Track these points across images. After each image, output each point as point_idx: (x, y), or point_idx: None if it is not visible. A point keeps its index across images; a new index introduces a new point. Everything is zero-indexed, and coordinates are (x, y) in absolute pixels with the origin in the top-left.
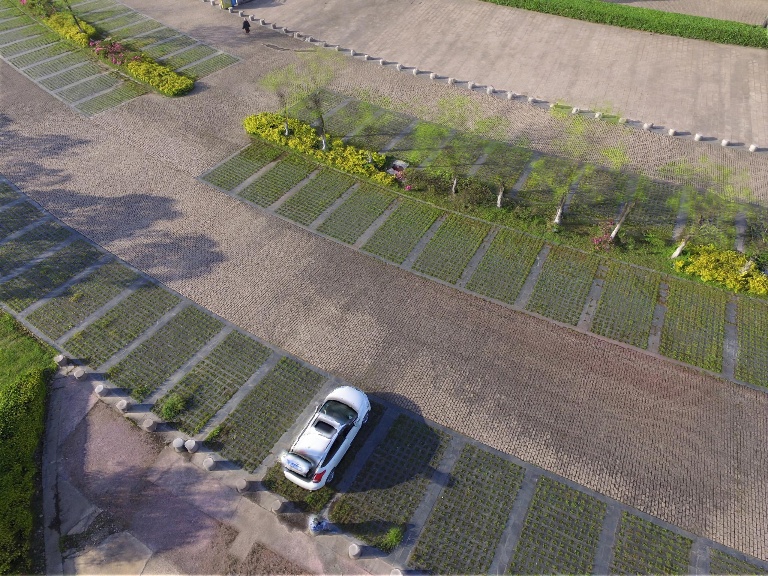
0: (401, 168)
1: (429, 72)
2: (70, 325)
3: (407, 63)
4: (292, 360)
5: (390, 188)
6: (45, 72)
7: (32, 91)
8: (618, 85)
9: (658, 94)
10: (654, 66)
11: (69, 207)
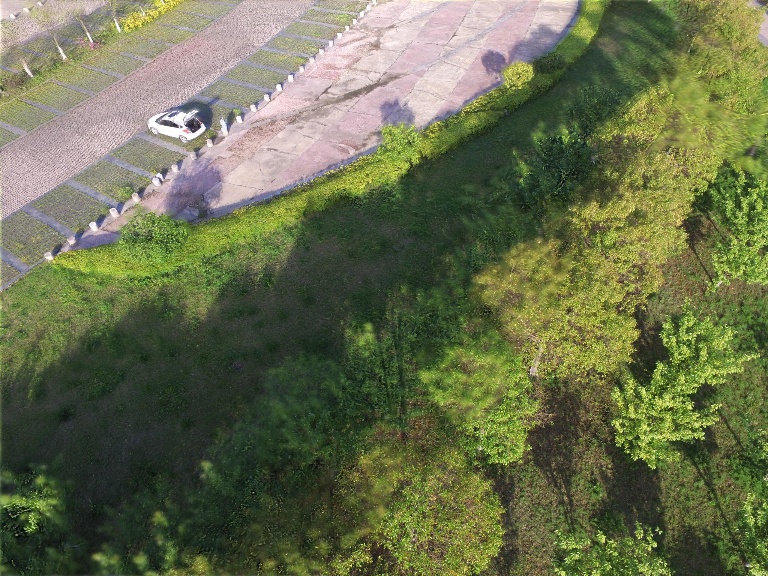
0: None
1: None
2: (8, 266)
3: None
4: (115, 151)
5: None
6: None
7: None
8: None
9: None
10: None
11: None
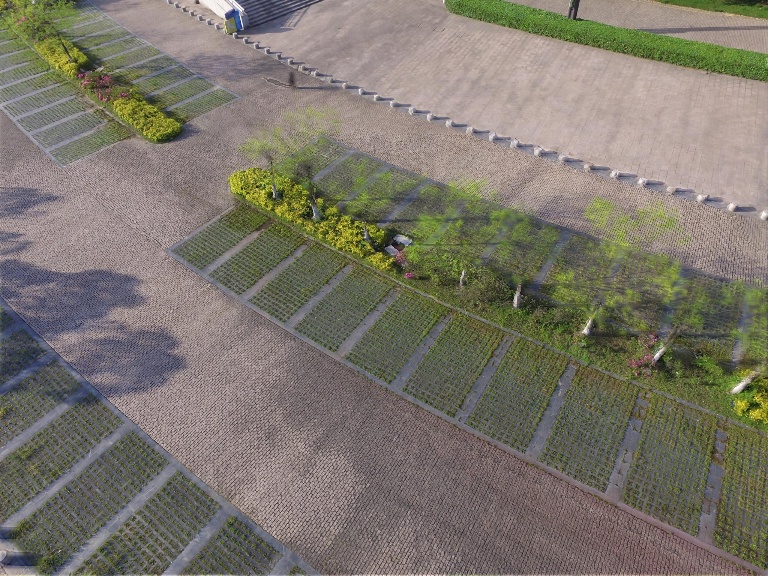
0: (402, 245)
1: (445, 118)
2: None
3: (421, 105)
4: (241, 523)
5: (386, 273)
6: (27, 108)
7: (8, 132)
8: (667, 140)
9: (715, 153)
10: (711, 115)
11: (19, 284)
